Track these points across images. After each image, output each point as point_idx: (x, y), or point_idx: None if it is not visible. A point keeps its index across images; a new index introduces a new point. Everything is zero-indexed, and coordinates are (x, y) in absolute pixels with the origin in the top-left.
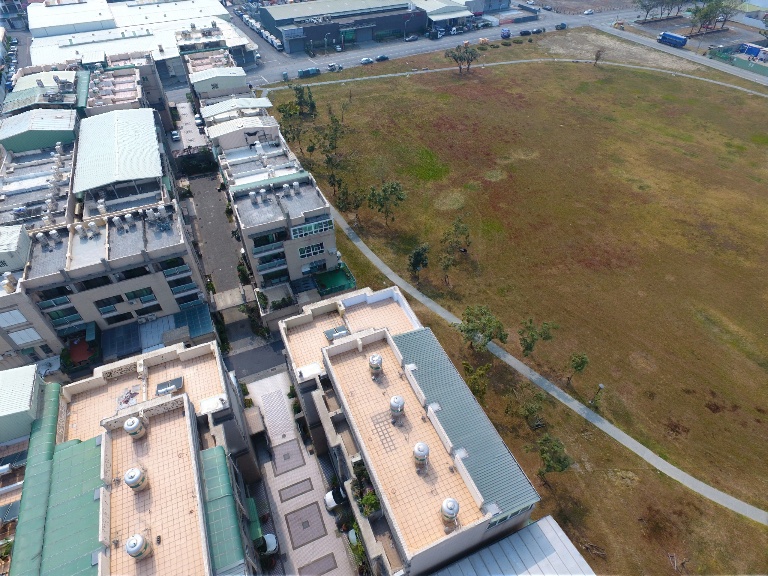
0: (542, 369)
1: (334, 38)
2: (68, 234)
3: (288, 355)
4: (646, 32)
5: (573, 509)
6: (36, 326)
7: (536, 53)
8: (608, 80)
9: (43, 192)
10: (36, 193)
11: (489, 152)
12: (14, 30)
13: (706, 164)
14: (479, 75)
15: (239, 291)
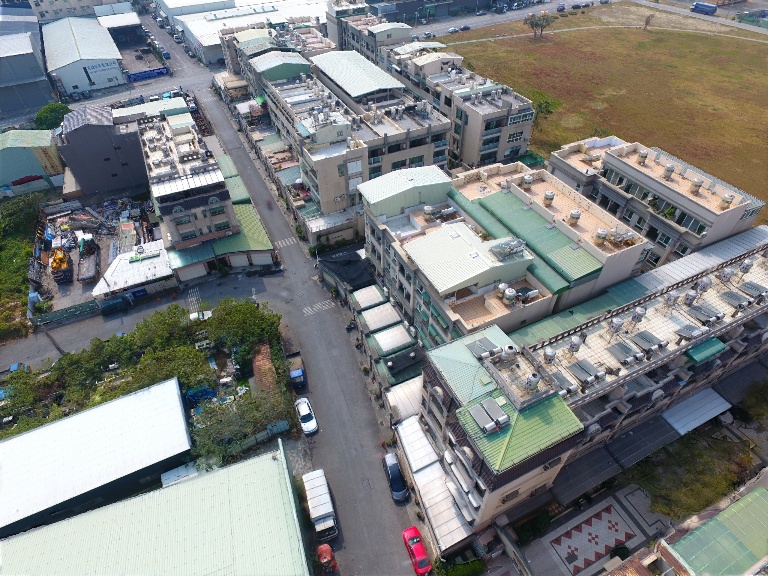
0: None
1: (419, 13)
2: (360, 122)
3: (569, 167)
4: (678, 4)
5: None
6: (364, 176)
7: (591, 22)
8: (660, 40)
9: (314, 103)
10: (310, 103)
11: (586, 91)
12: None
13: (759, 94)
14: (551, 39)
15: (464, 168)
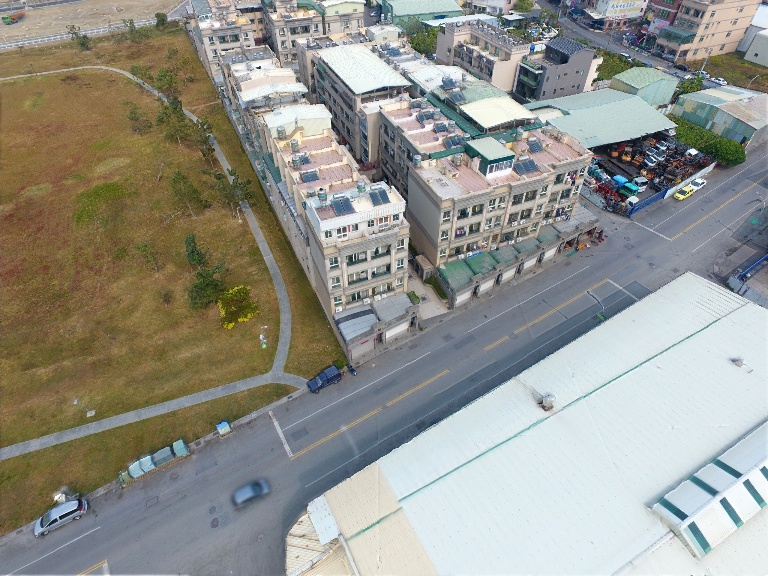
0: None
1: None
2: None
3: None
4: None
5: (173, 69)
6: None
7: None
8: None
9: None
10: None
11: (4, 219)
12: None
13: None
14: None
15: None
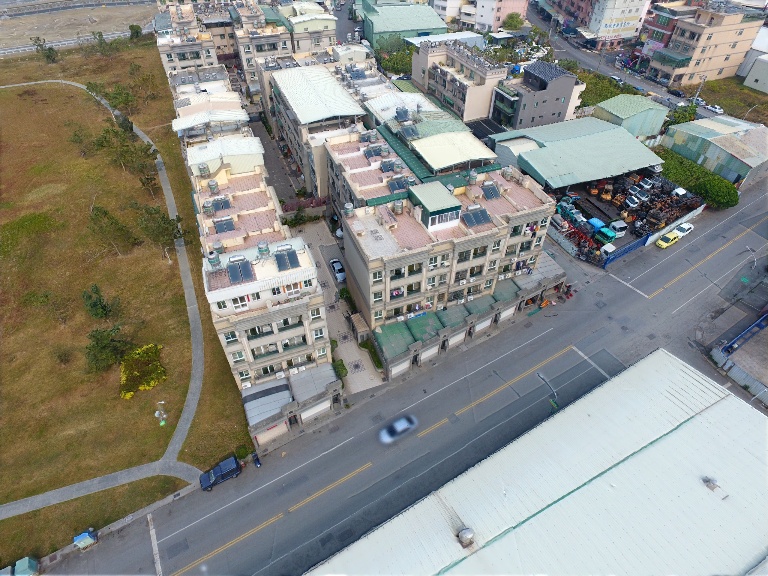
0: (104, 109)
1: None
2: None
3: None
4: None
5: None
6: None
7: None
8: None
9: None
10: None
11: None
12: None
13: None
14: None
15: None
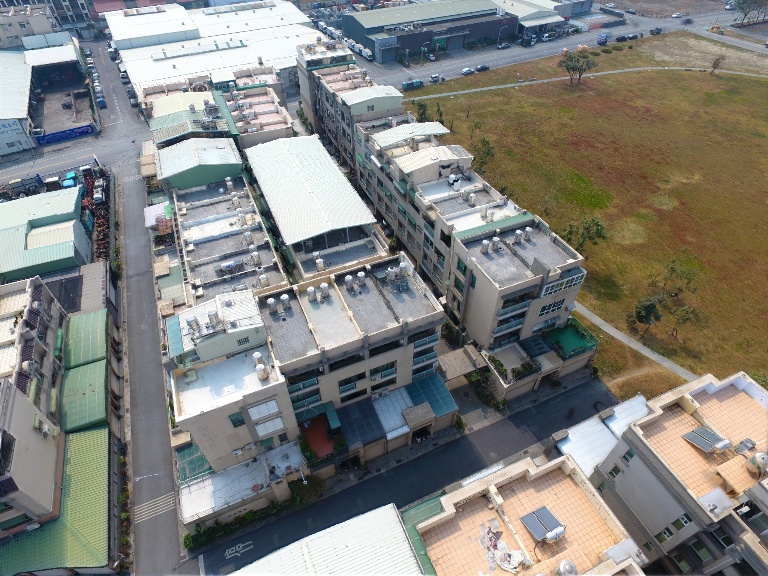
0: None
1: (426, 46)
2: (292, 296)
3: (671, 476)
4: (748, 37)
5: None
6: (284, 415)
7: (641, 61)
8: (734, 90)
9: (233, 239)
10: (226, 241)
11: (645, 175)
12: (82, 40)
13: None
14: (592, 86)
15: (466, 355)
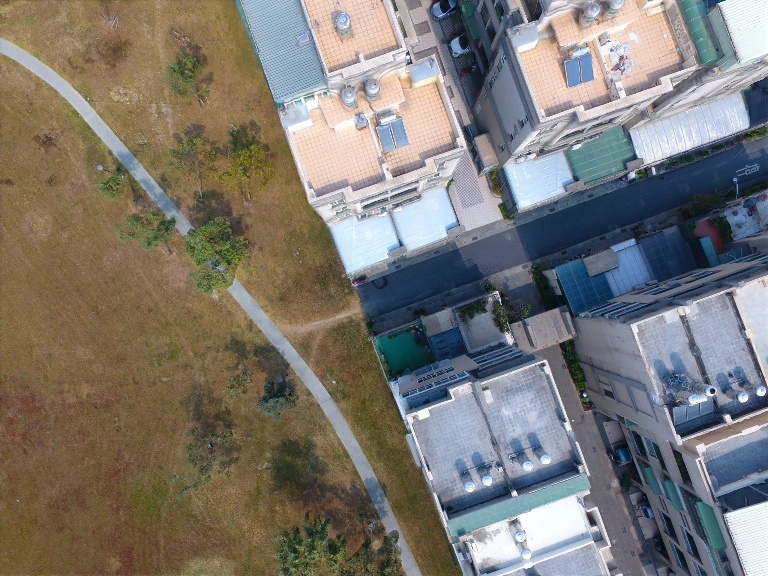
0: None
1: None
2: None
3: None
4: None
5: None
6: None
7: None
8: None
9: None
10: None
11: None
12: None
13: None
14: None
15: None
